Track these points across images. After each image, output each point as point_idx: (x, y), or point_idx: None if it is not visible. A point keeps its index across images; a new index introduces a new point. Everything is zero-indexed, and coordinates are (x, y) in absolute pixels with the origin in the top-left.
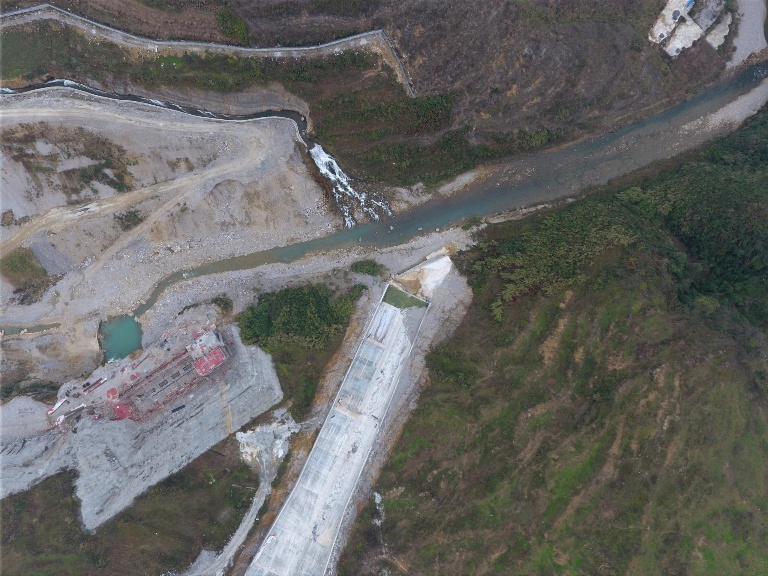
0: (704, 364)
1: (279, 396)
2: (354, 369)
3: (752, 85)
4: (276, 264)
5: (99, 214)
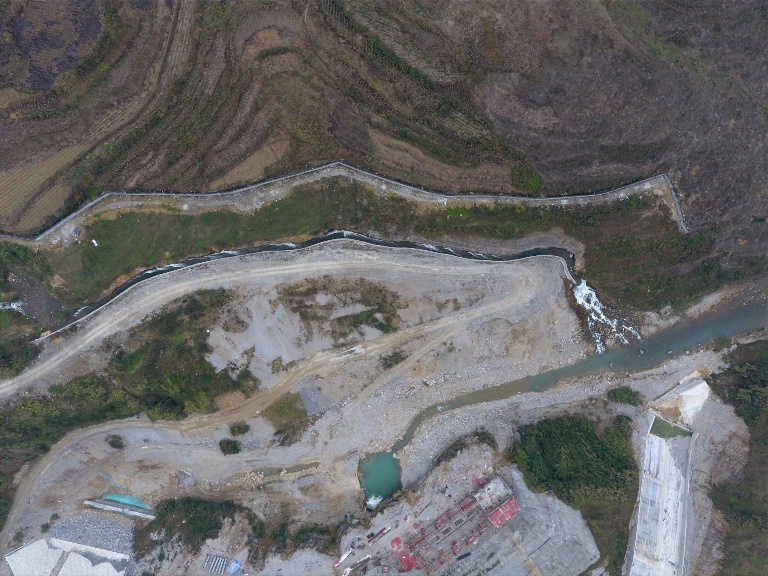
0: None
1: (596, 555)
2: (640, 511)
3: None
4: (529, 393)
5: (365, 356)
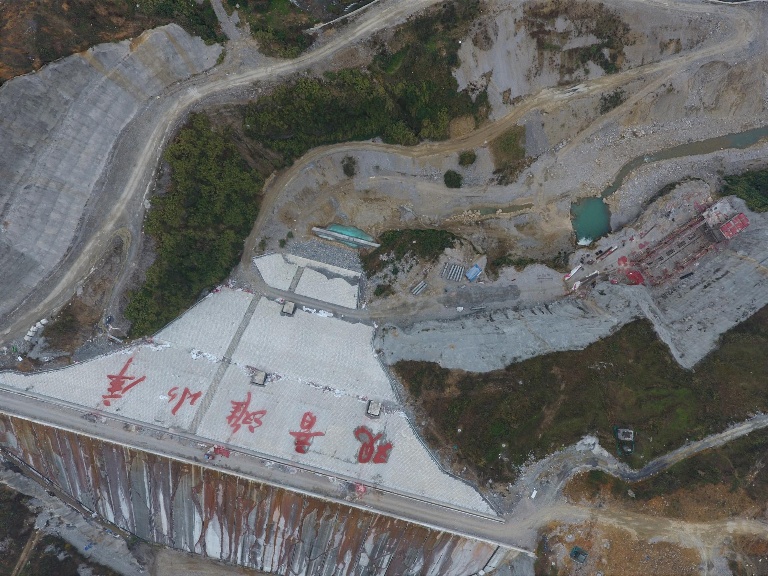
0: None
1: None
2: None
3: None
4: (732, 149)
5: (588, 94)
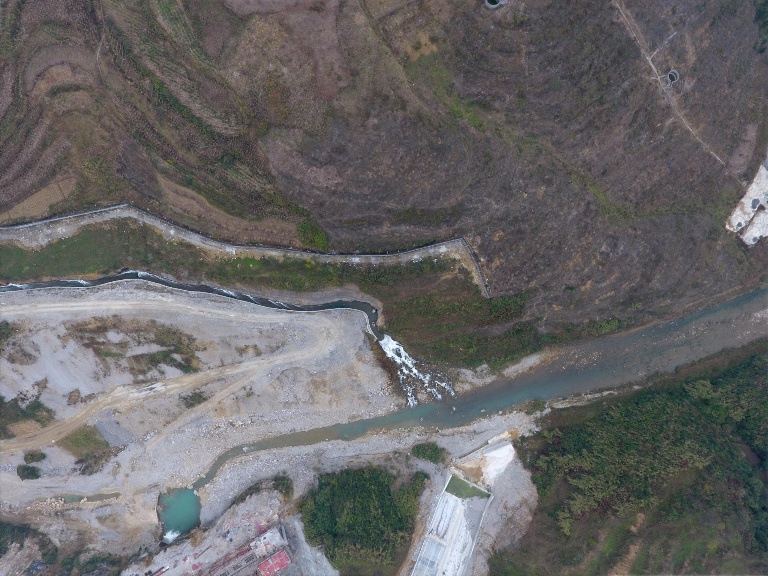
0: None
1: None
2: (416, 571)
3: None
4: (336, 441)
5: (164, 394)
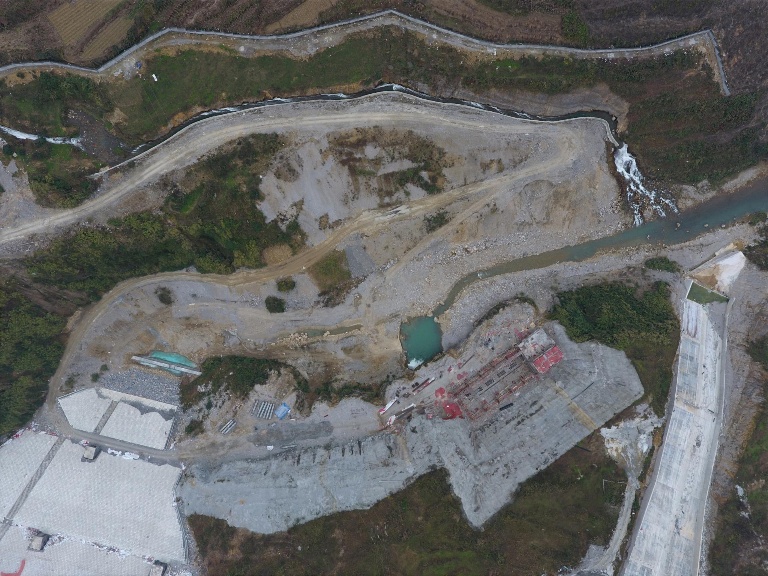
0: None
1: (640, 391)
2: None
3: None
4: (568, 263)
5: (410, 216)
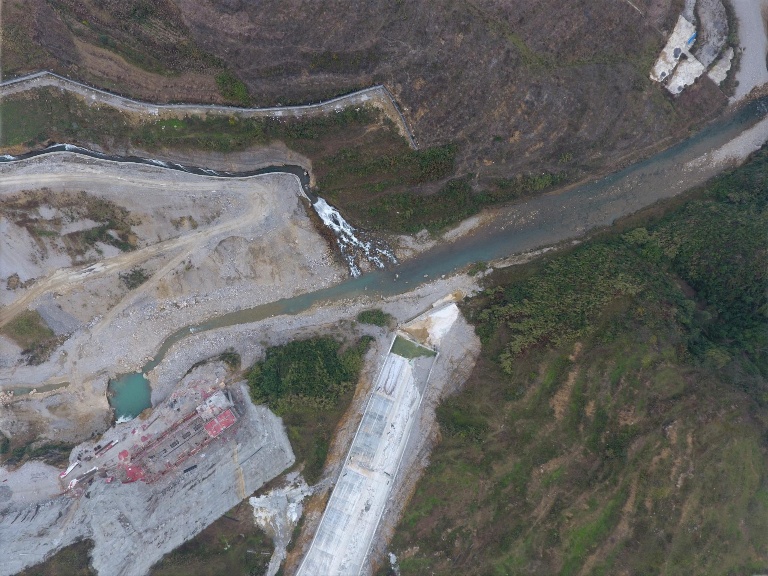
0: (716, 420)
1: (291, 460)
2: (364, 424)
3: (755, 119)
4: (283, 316)
5: (104, 274)
